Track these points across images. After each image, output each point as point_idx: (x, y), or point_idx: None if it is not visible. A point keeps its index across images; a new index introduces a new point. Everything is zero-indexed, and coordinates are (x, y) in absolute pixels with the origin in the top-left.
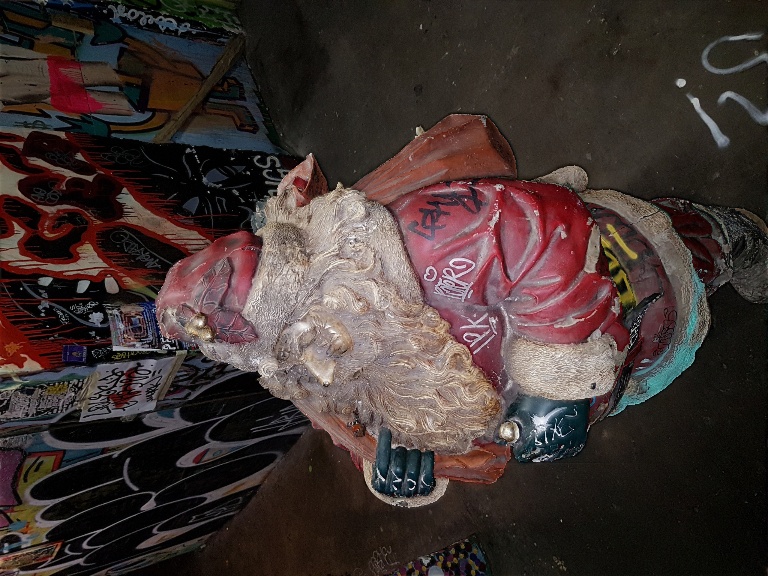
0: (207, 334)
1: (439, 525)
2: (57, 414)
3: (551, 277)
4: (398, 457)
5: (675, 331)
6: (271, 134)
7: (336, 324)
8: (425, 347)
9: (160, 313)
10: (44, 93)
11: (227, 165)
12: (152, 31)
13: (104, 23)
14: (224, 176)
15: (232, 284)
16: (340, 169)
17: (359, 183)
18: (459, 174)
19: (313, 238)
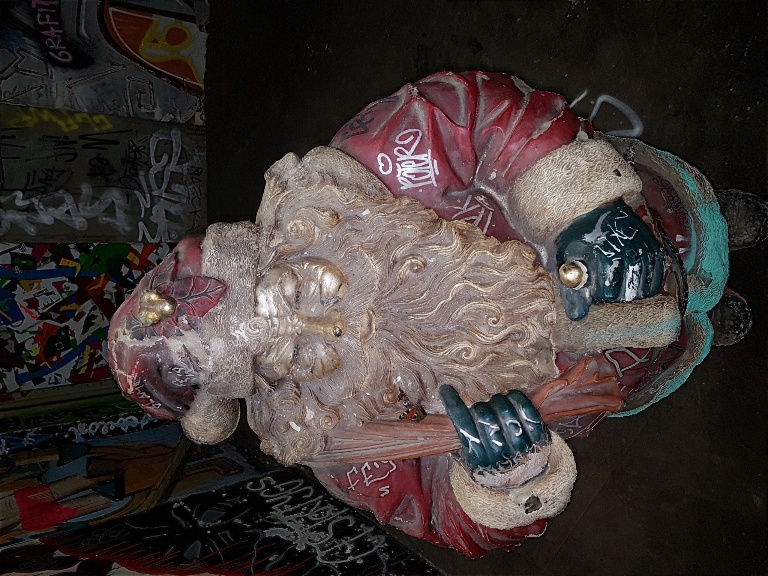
0: (164, 303)
1: None
2: None
3: (499, 107)
4: (479, 407)
5: (681, 198)
6: (258, 467)
7: (315, 260)
8: (422, 233)
9: (111, 349)
10: (14, 522)
11: (220, 502)
12: (116, 435)
13: (67, 446)
14: (220, 512)
15: (180, 260)
16: None
17: None
18: None
19: (258, 219)
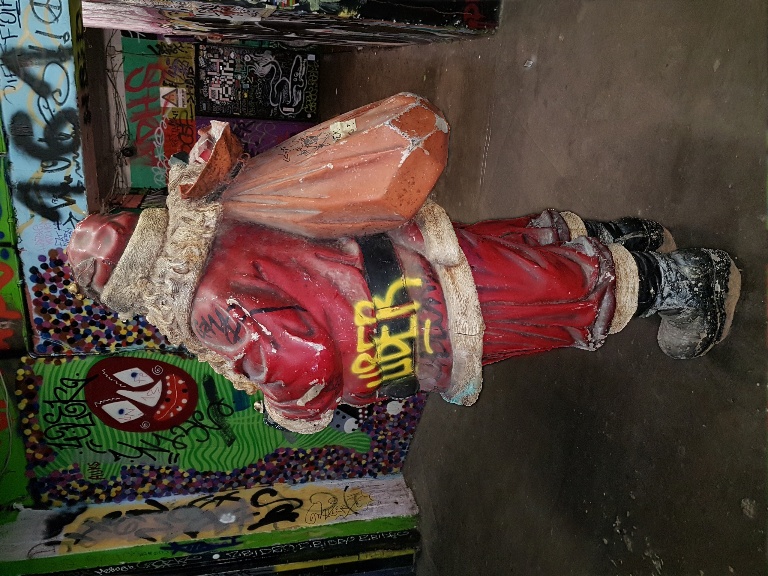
0: None
1: (459, 218)
2: (172, 7)
3: None
4: None
5: (446, 393)
6: None
7: None
8: None
9: None
10: None
11: None
12: None
13: None
14: None
15: (94, 281)
16: None
17: (255, 177)
18: (335, 215)
19: (155, 268)
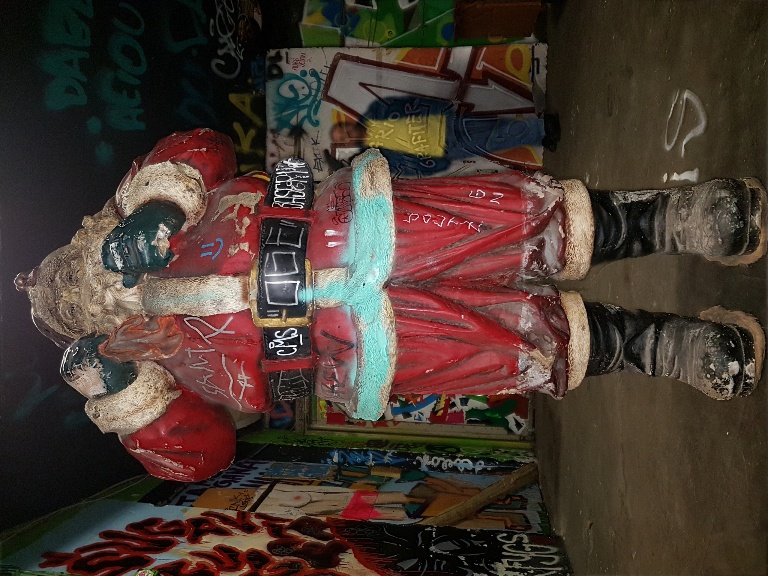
0: None
1: None
2: None
3: None
4: None
5: None
6: (544, 531)
7: None
8: None
9: None
10: (340, 509)
11: (463, 539)
12: (452, 473)
13: (413, 471)
14: (456, 546)
15: None
16: (576, 522)
17: None
18: None
19: None
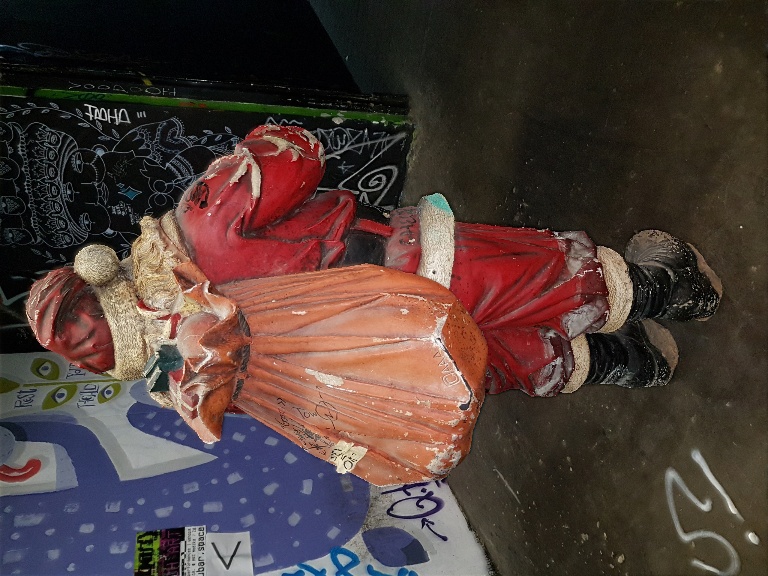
0: None
1: None
2: None
3: None
4: None
5: None
6: None
7: None
8: None
9: None
10: None
11: None
12: None
13: None
14: None
15: None
16: None
17: None
18: None
19: None
